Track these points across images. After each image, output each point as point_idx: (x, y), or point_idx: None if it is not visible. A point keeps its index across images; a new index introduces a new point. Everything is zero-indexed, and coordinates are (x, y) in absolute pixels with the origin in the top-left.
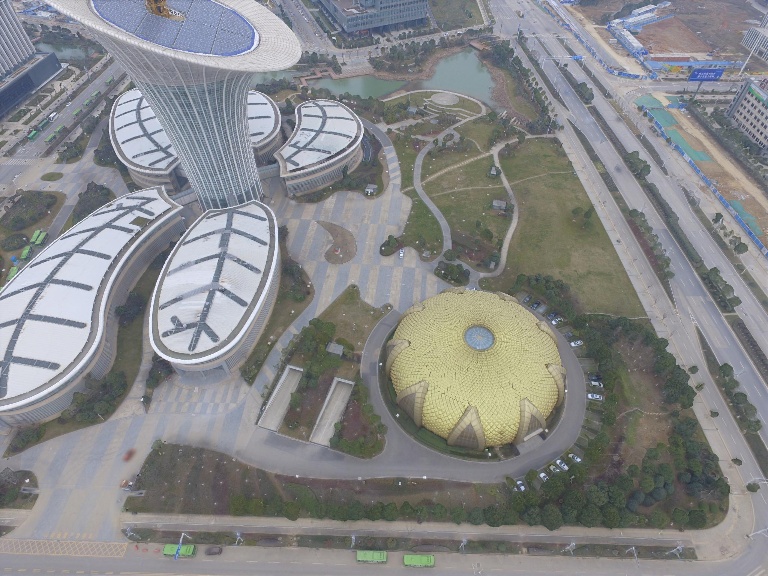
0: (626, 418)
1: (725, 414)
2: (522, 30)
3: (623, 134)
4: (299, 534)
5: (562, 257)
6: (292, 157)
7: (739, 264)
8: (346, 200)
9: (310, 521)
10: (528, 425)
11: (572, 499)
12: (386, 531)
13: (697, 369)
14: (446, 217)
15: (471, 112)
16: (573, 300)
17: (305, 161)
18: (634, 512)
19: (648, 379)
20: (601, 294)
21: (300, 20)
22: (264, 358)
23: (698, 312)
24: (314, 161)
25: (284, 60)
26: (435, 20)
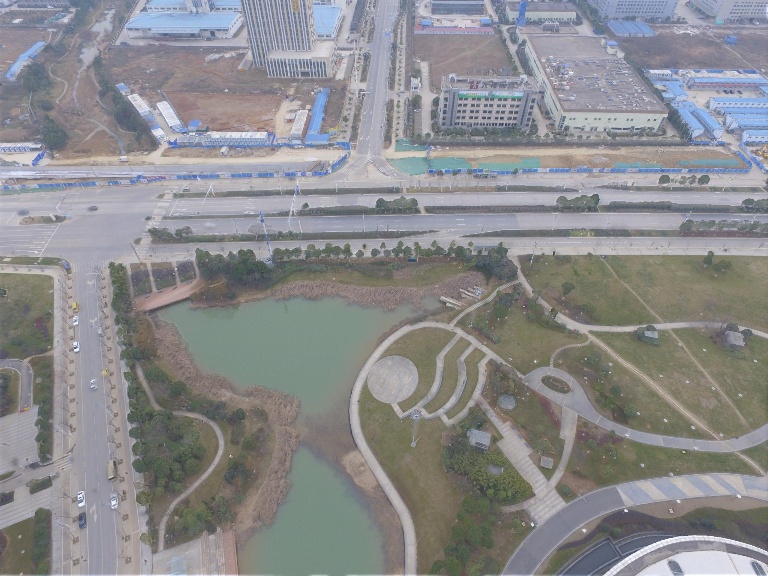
0: None
1: None
2: (152, 227)
3: (496, 200)
4: None
5: None
6: None
7: (710, 188)
8: None
9: None
10: None
11: None
12: None
13: None
14: None
15: (450, 343)
16: None
17: None
18: None
19: None
20: None
21: None
22: None
23: None
24: None
25: None
26: None
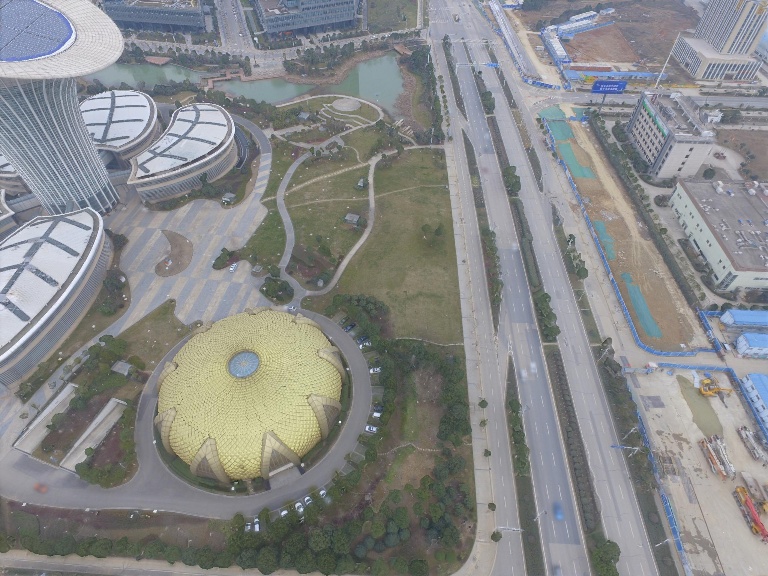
0: (395, 454)
1: (504, 453)
2: (448, 35)
3: (513, 147)
4: (9, 567)
5: (396, 276)
6: (145, 163)
7: (580, 290)
8: (201, 209)
9: (26, 553)
10: (269, 460)
11: (288, 543)
12: (100, 567)
13: (486, 403)
14: (295, 230)
15: (366, 119)
16: (390, 323)
17: (157, 168)
18: (361, 558)
19: (436, 412)
20: (423, 317)
21: (230, 19)
22: (49, 375)
23: (518, 340)
24: (166, 168)
25: (84, 66)
26: (367, 22)
